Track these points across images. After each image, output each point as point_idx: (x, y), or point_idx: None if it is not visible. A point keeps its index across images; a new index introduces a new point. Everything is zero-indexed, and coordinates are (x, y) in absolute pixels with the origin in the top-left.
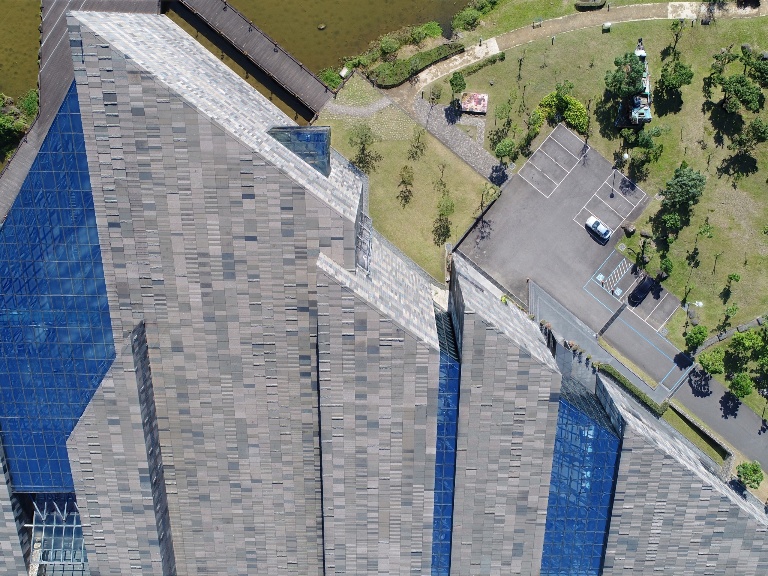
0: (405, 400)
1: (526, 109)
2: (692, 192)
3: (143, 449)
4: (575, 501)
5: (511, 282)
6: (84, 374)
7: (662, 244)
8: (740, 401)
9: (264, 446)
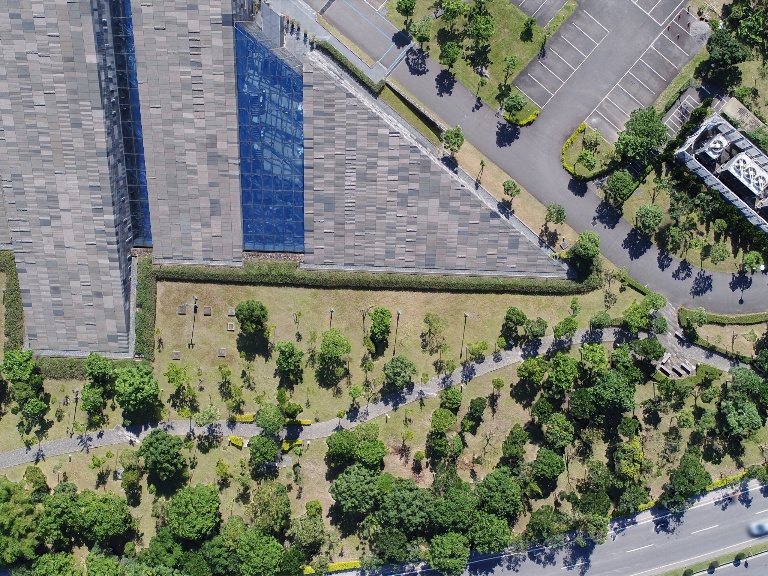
0: None
1: None
2: None
3: None
4: (290, 179)
5: None
6: None
7: None
8: (456, 79)
9: None
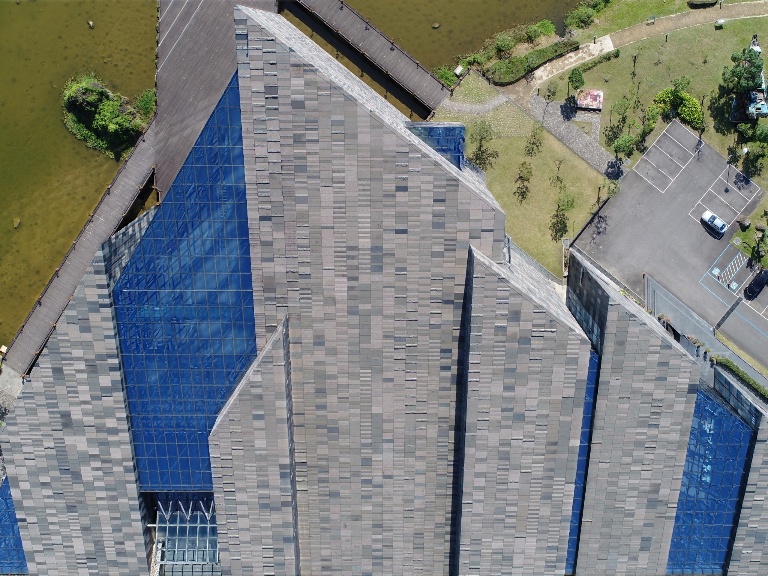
0: (553, 392)
1: (641, 105)
2: None
3: (286, 444)
4: (695, 495)
5: (627, 277)
6: (222, 370)
7: None
8: None
9: (398, 441)
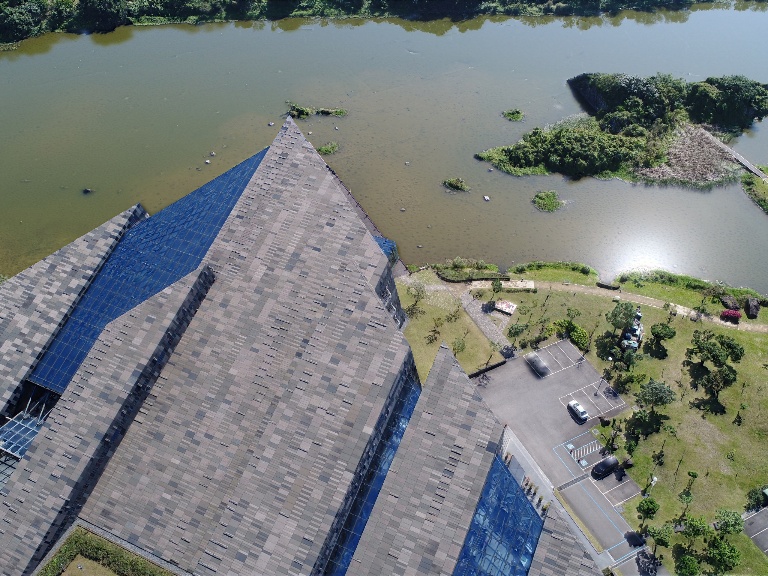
0: (367, 376)
1: (543, 323)
2: (661, 394)
3: (154, 348)
4: None
5: None
6: None
7: (632, 439)
8: None
9: (235, 405)
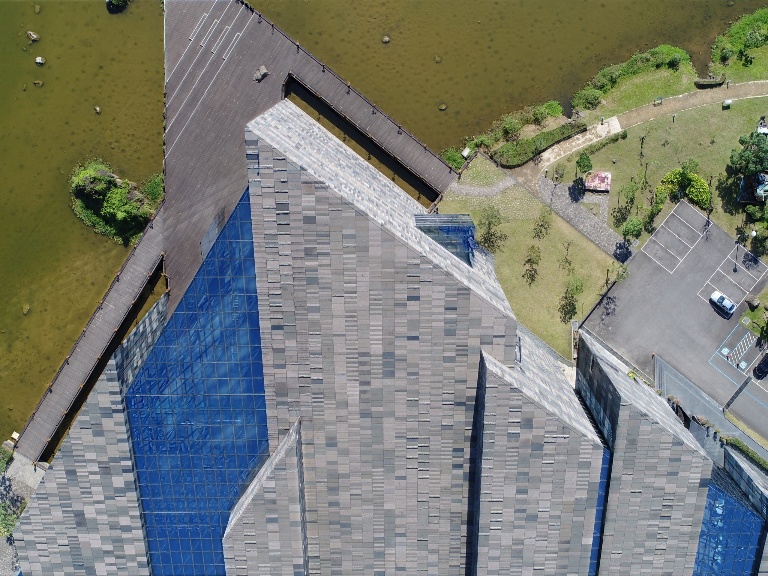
0: (565, 494)
1: (648, 186)
2: None
3: (299, 546)
4: (706, 575)
5: (637, 357)
6: (234, 469)
7: None
8: None
9: (411, 535)
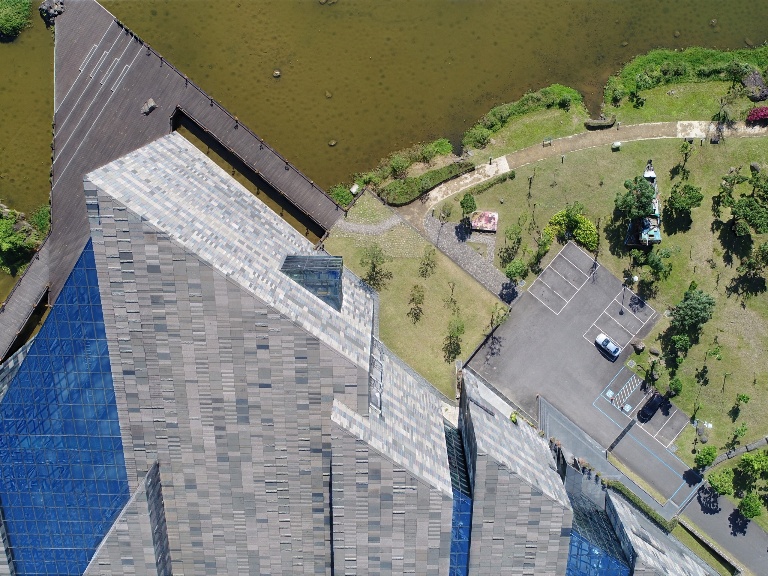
0: (418, 543)
1: (536, 227)
2: (702, 316)
3: None
4: None
5: (521, 398)
6: (97, 508)
7: (671, 361)
8: (749, 518)
9: (276, 575)
